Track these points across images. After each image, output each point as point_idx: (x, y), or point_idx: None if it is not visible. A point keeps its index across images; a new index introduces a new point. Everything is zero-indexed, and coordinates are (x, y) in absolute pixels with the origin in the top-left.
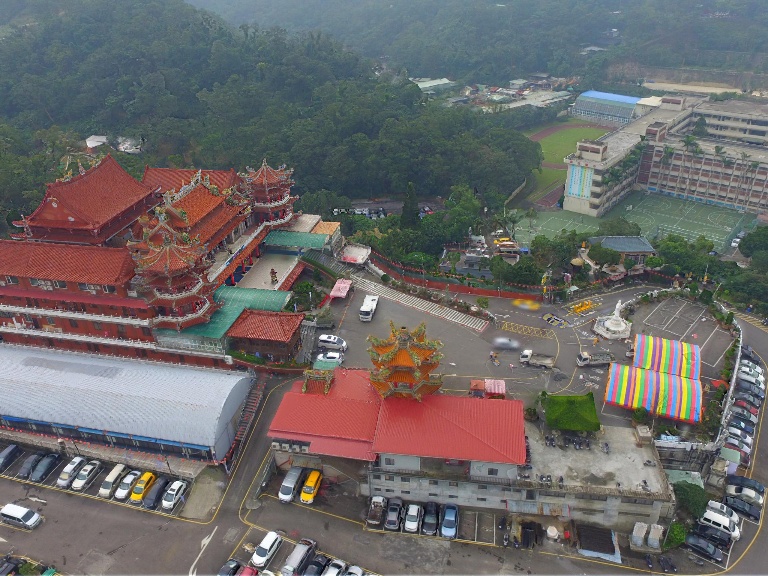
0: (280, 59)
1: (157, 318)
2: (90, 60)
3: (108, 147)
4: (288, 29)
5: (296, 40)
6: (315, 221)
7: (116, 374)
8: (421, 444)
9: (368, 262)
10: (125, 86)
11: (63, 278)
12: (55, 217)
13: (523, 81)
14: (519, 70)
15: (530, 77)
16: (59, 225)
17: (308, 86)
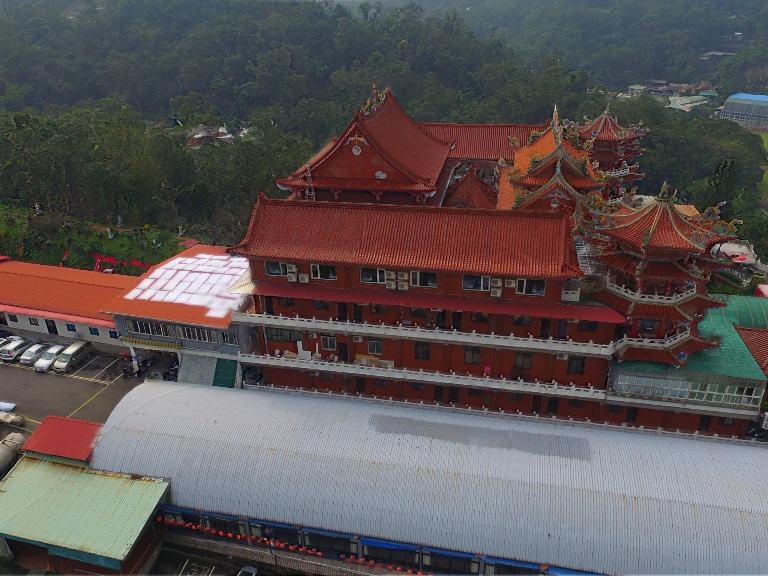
0: (418, 40)
1: (620, 341)
2: (192, 35)
3: (267, 120)
4: (424, 7)
5: (433, 20)
6: None
7: (587, 451)
8: None
9: (756, 262)
10: (234, 67)
11: (446, 265)
12: (350, 173)
13: (642, 87)
14: (635, 75)
15: (645, 84)
16: (361, 185)
17: (453, 71)
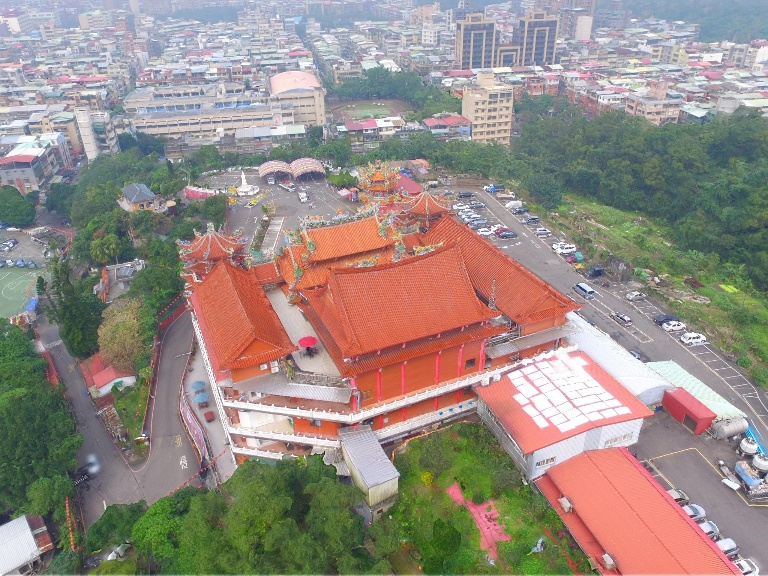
0: None
1: None
2: None
3: None
4: None
5: None
6: None
7: None
8: (413, 184)
9: None
10: None
11: (499, 250)
12: None
13: None
14: None
15: None
16: None
17: None
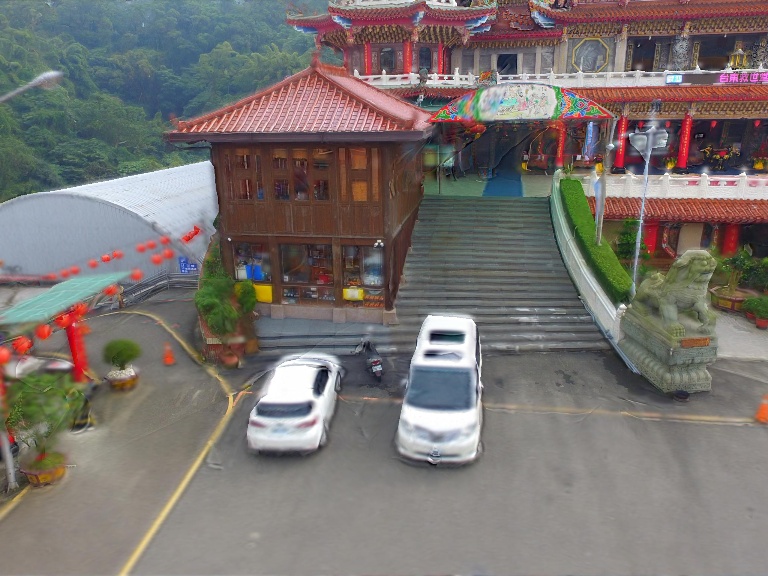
0: None
1: None
2: None
3: None
4: None
5: None
6: None
7: None
8: None
9: None
10: None
11: None
12: None
13: None
14: None
15: None
16: None
17: None
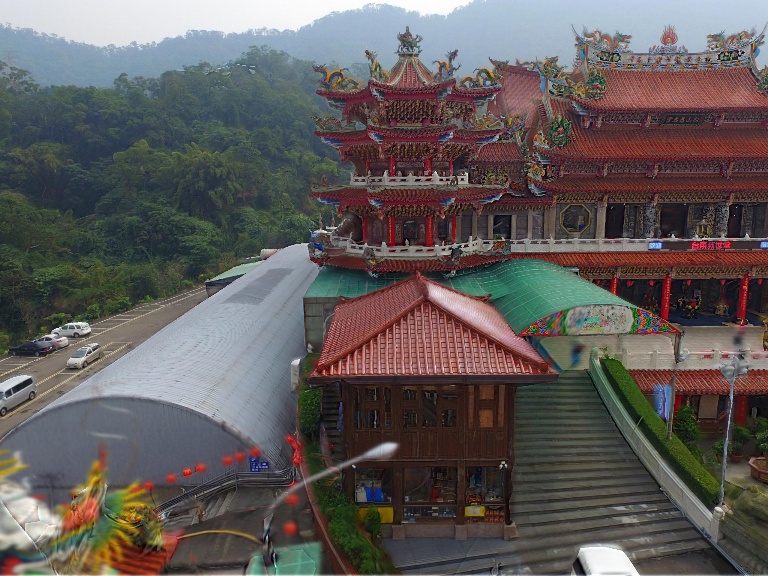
0: None
1: None
2: None
3: None
4: None
5: None
6: None
7: None
8: None
9: None
10: None
11: None
12: None
13: None
14: None
15: None
16: None
17: None
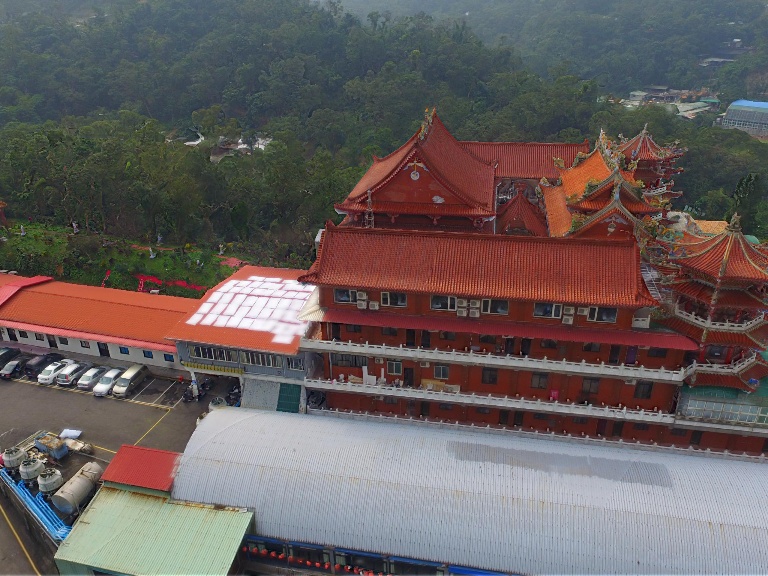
0: (428, 49)
1: (690, 367)
2: (203, 45)
3: (290, 133)
4: (433, 16)
5: (443, 29)
6: (691, 219)
7: (668, 478)
8: None
9: None
10: (246, 76)
11: (521, 294)
12: (407, 197)
13: (643, 93)
14: (636, 81)
15: (646, 90)
16: (419, 210)
17: (464, 80)
